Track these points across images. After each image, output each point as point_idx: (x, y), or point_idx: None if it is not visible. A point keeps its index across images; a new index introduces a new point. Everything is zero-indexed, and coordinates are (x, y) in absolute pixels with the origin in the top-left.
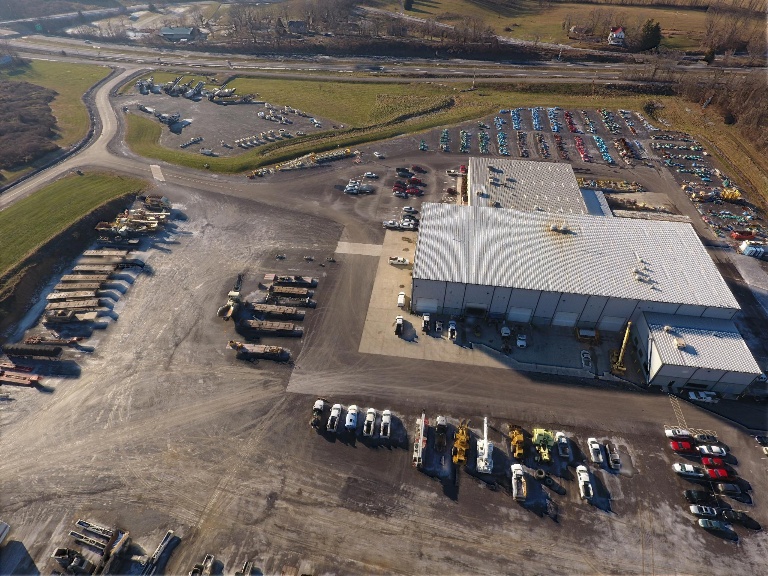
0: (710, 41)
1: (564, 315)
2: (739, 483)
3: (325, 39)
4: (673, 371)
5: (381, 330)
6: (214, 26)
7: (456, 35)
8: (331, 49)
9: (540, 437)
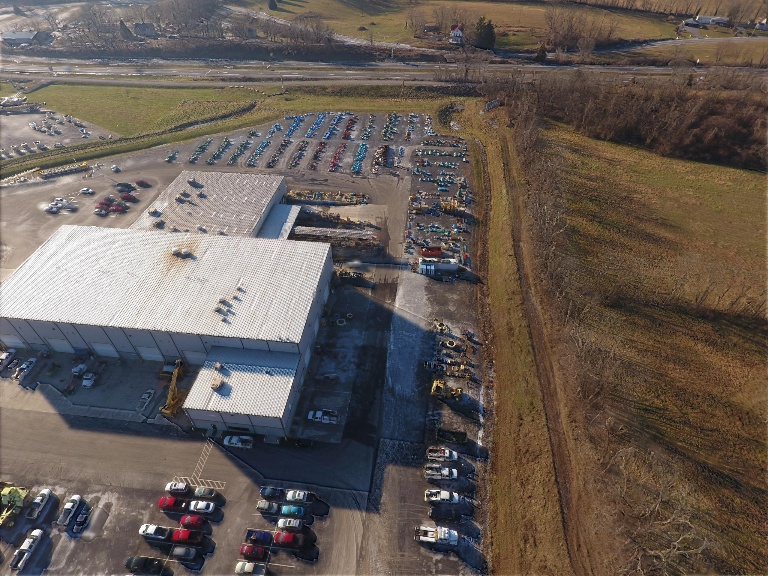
0: (547, 38)
1: (146, 350)
2: (204, 545)
3: (165, 42)
4: (202, 415)
5: None
6: (70, 29)
7: (291, 36)
8: (167, 52)
9: (5, 497)
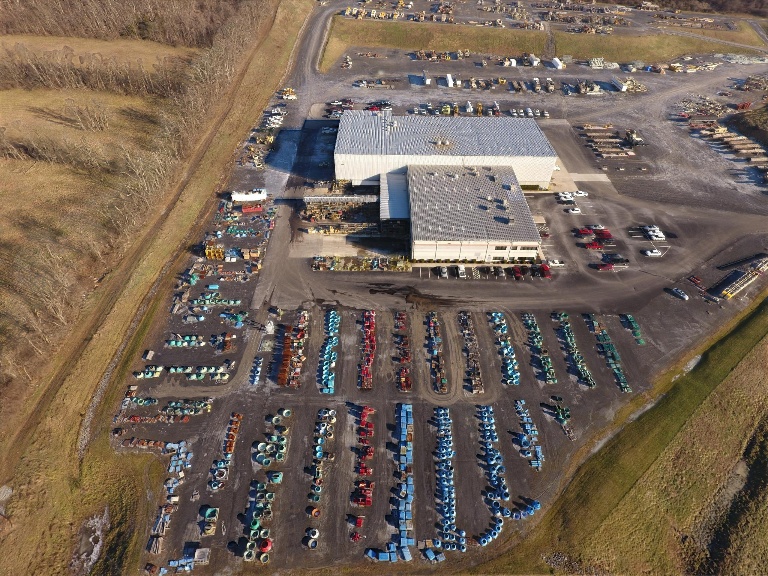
0: None
1: None
2: None
3: None
4: None
5: None
6: None
7: None
8: None
9: None
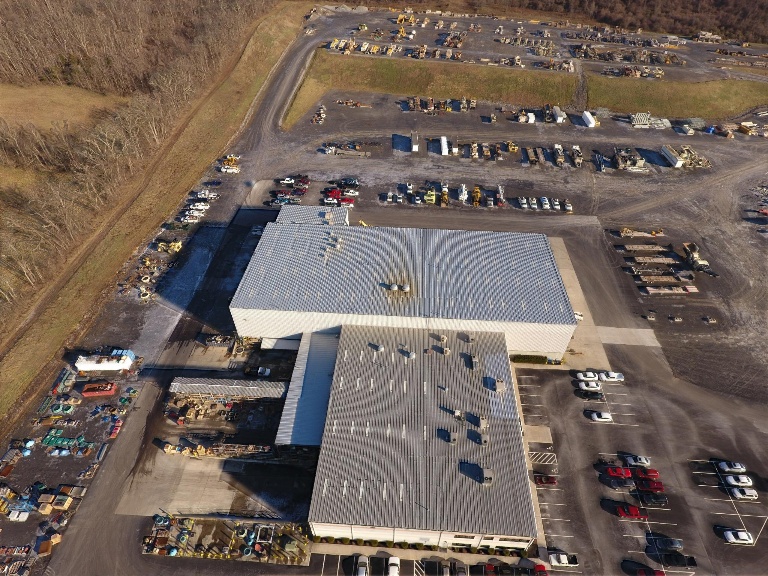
0: None
1: None
2: None
3: None
4: None
5: (553, 252)
6: None
7: None
8: None
9: None
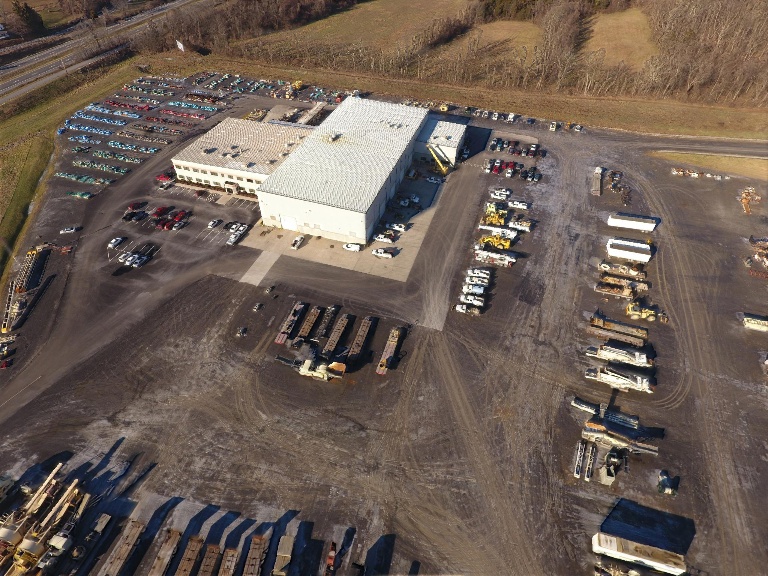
0: (75, 8)
1: None
2: (514, 164)
3: None
4: None
5: (384, 266)
6: None
7: None
8: None
9: None
